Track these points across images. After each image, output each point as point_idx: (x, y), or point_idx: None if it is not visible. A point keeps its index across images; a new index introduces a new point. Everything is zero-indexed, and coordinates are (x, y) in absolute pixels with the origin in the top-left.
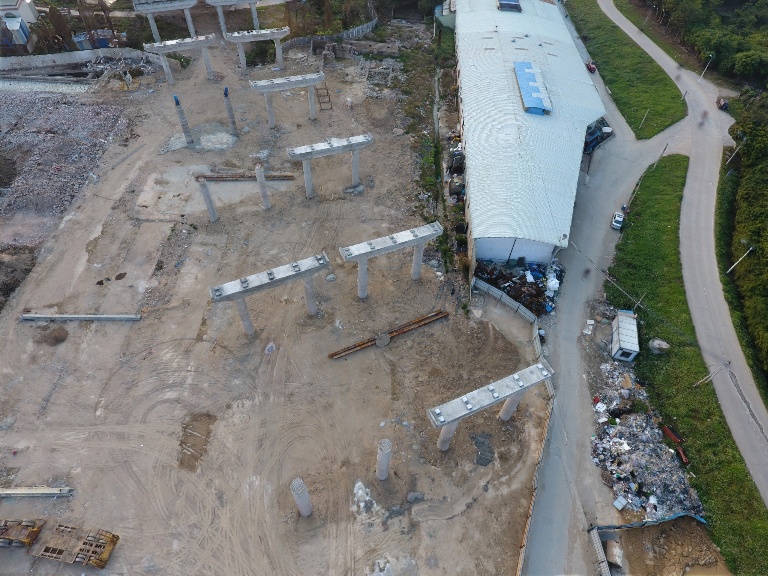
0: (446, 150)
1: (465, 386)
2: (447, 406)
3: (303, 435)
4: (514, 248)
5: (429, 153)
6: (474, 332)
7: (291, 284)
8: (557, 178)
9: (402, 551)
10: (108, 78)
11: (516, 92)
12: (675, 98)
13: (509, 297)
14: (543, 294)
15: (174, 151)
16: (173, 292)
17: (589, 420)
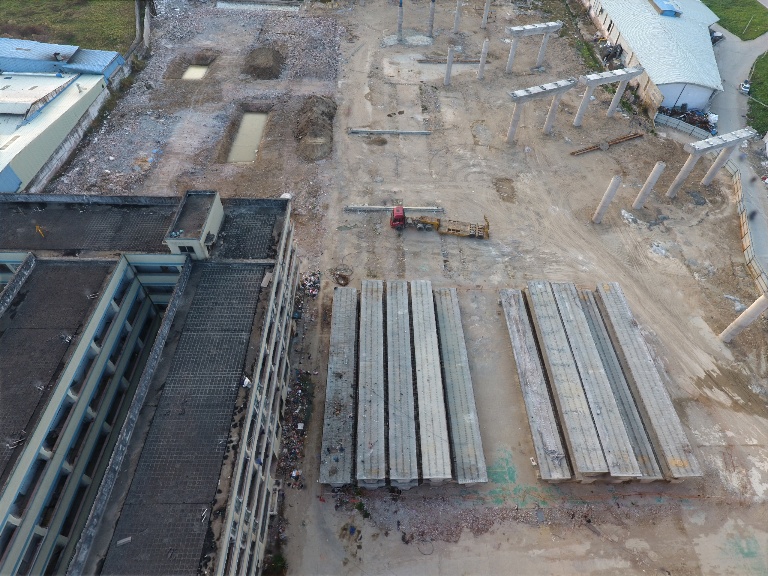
0: (595, 48)
1: (671, 170)
2: (697, 143)
3: (575, 189)
4: (681, 95)
5: (584, 49)
6: (665, 144)
7: (523, 119)
8: (701, 53)
9: (666, 239)
10: (311, 2)
11: (648, 3)
12: (766, 14)
13: (686, 123)
14: (708, 123)
15: (391, 46)
16: (443, 121)
17: (763, 187)
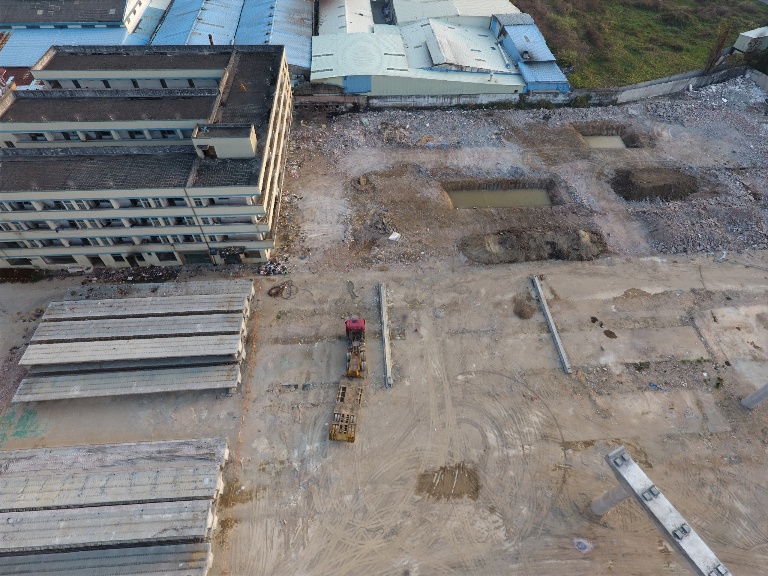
0: None
1: None
2: None
3: None
4: None
5: None
6: None
7: None
8: None
9: None
10: None
11: None
12: None
13: None
14: None
15: None
16: (614, 394)
17: None
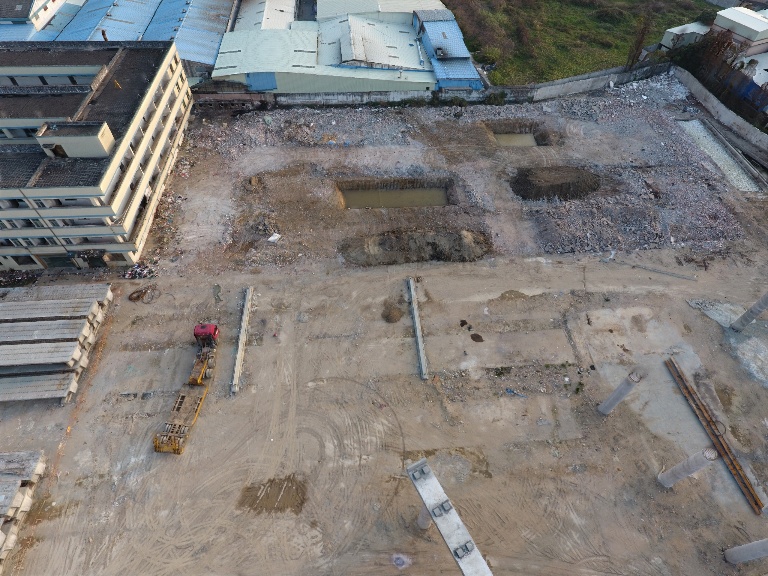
0: None
1: None
2: None
3: None
4: None
5: None
6: None
7: (521, 567)
8: None
9: None
10: None
11: None
12: None
13: None
14: None
15: (705, 316)
16: (467, 400)
17: None
